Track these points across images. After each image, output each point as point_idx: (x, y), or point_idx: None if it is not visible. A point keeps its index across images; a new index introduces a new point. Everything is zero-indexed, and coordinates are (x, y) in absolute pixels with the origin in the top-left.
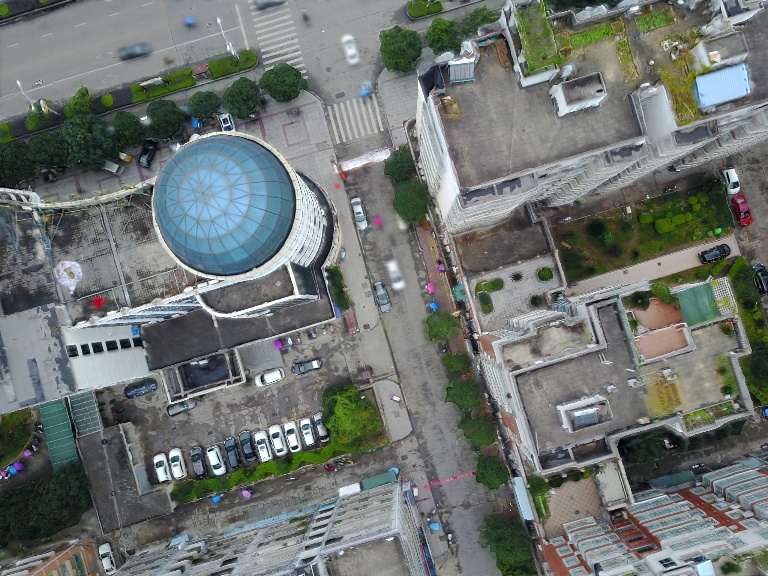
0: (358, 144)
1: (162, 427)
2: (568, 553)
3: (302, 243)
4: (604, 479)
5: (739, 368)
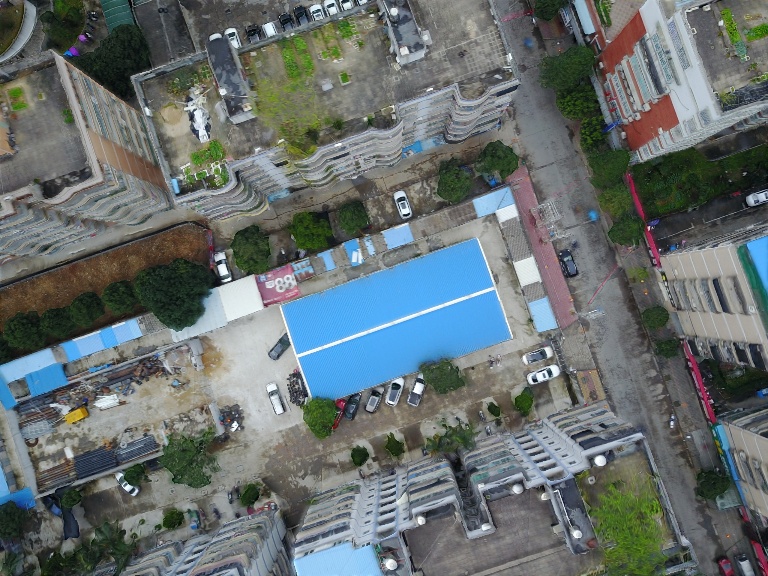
0: None
1: (216, 10)
2: None
3: None
4: None
5: None
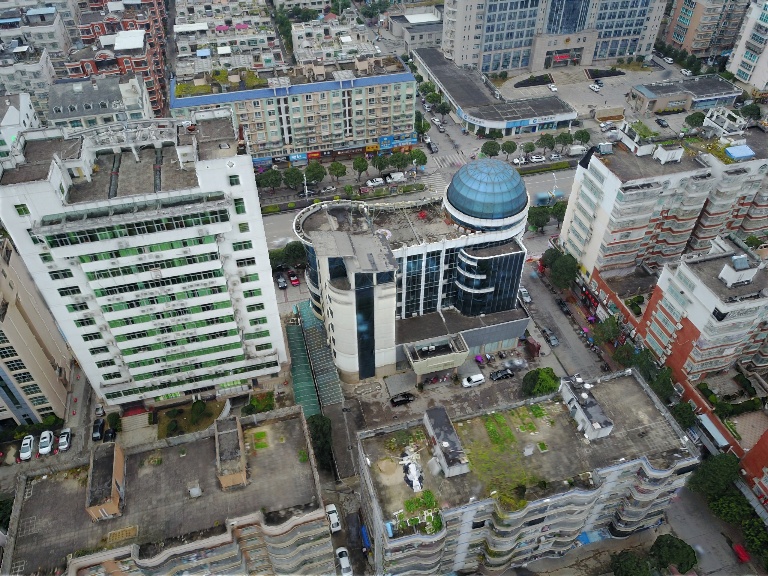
0: None
1: (385, 416)
2: None
3: None
4: None
5: None
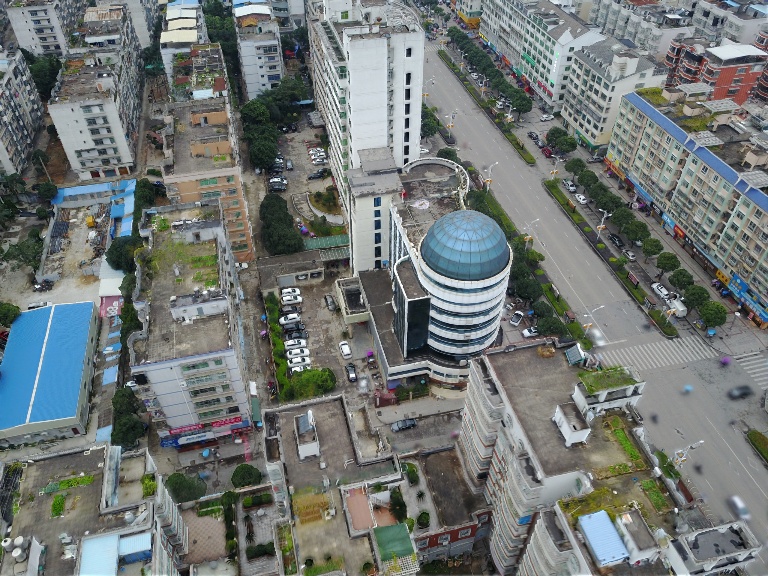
0: None
1: (318, 294)
2: None
3: (444, 305)
4: (220, 569)
5: (330, 573)
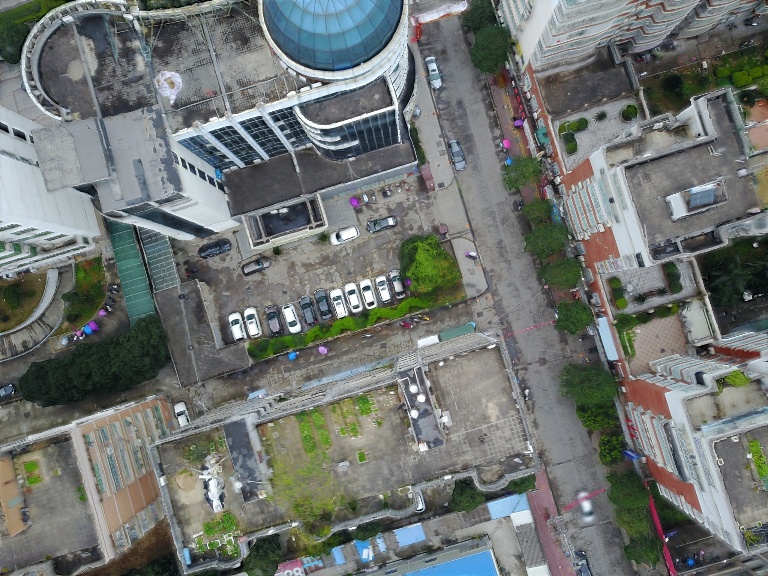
0: (431, 4)
1: (236, 287)
2: (659, 380)
3: (400, 55)
4: (689, 317)
5: None
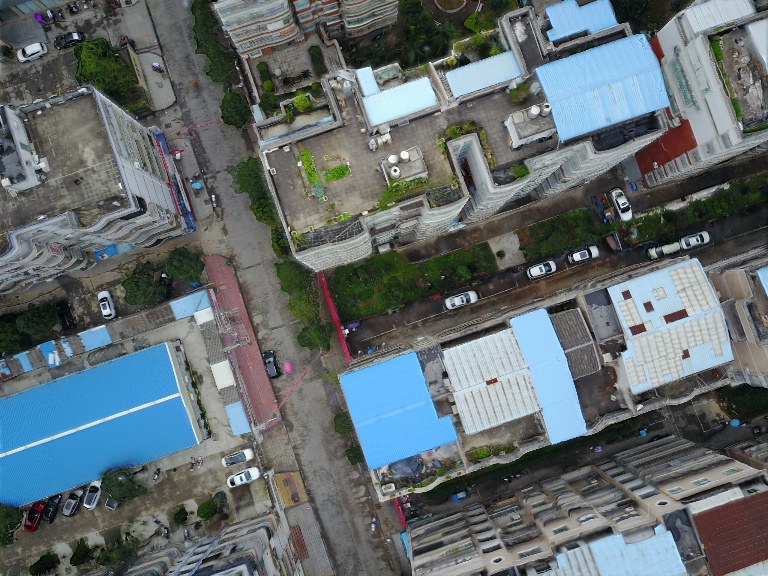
0: None
1: None
2: None
3: None
4: None
5: None
